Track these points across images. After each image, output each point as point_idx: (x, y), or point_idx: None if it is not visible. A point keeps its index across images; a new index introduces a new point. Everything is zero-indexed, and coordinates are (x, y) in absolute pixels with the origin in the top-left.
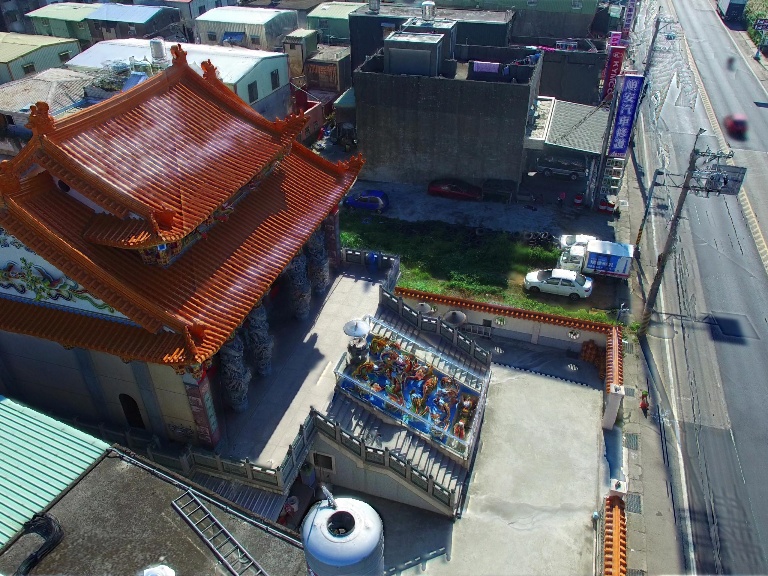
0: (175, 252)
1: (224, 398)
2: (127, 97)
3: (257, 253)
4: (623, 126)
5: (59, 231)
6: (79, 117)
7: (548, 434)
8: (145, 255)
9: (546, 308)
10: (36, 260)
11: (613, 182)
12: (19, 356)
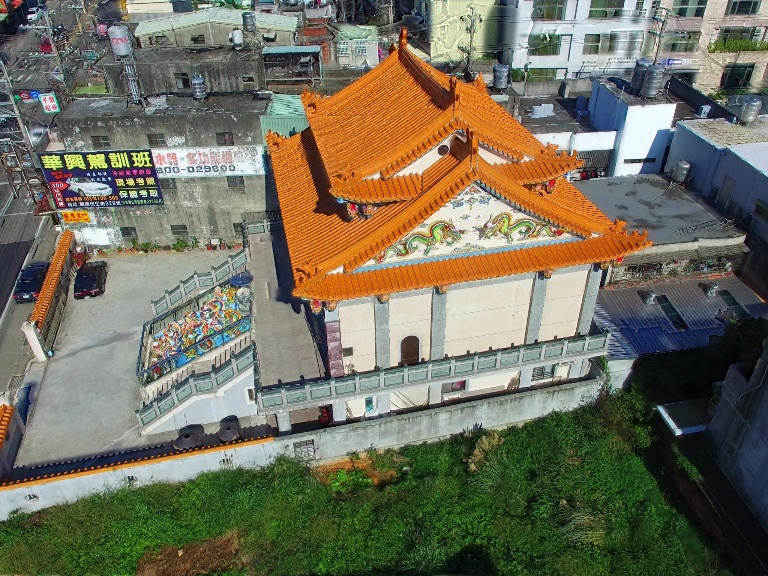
0: None
1: None
2: None
3: None
4: None
5: None
6: None
7: (82, 399)
8: None
9: (68, 571)
10: None
11: None
12: None
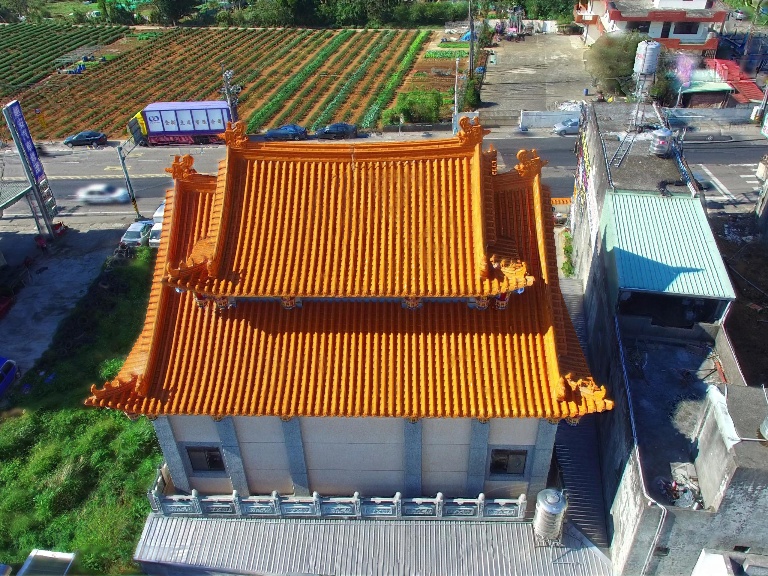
0: None
1: None
2: None
3: None
4: (31, 151)
5: None
6: None
7: None
8: None
9: None
10: None
11: (51, 204)
12: None
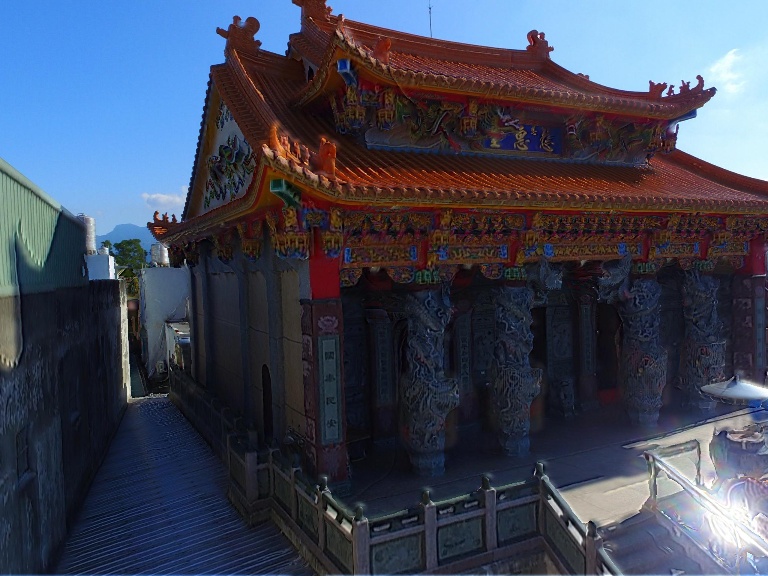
0: (381, 117)
1: (398, 428)
2: (444, 46)
3: (533, 185)
4: None
5: (266, 94)
6: (367, 29)
7: None
8: (337, 112)
9: None
10: (234, 132)
11: None
12: (219, 320)
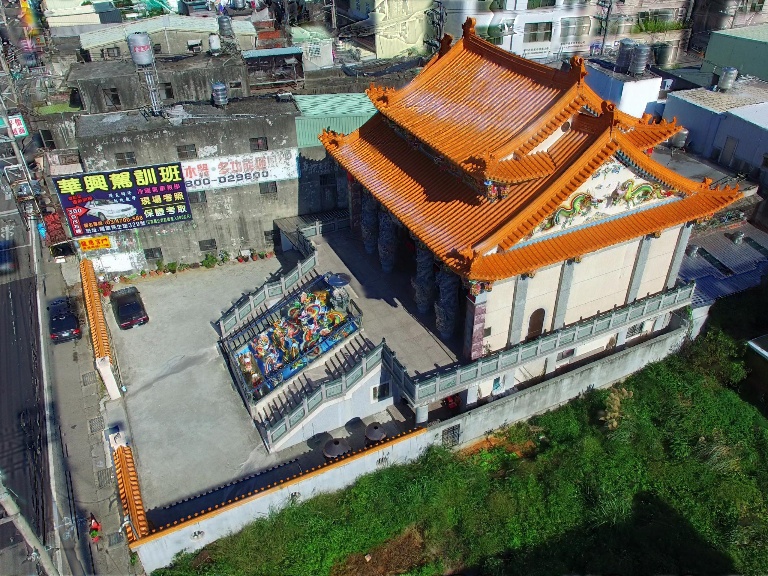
0: None
1: None
2: (517, 61)
3: None
4: None
5: None
6: None
7: (185, 429)
8: None
9: None
10: None
11: None
12: None
